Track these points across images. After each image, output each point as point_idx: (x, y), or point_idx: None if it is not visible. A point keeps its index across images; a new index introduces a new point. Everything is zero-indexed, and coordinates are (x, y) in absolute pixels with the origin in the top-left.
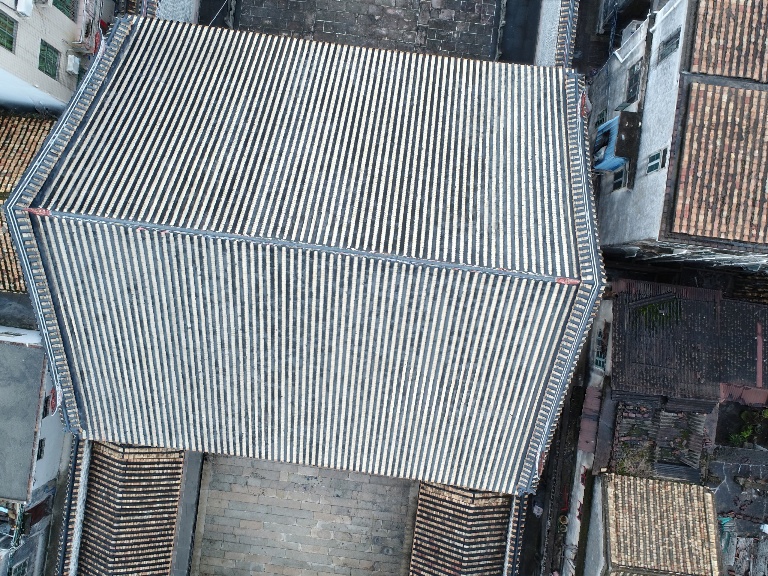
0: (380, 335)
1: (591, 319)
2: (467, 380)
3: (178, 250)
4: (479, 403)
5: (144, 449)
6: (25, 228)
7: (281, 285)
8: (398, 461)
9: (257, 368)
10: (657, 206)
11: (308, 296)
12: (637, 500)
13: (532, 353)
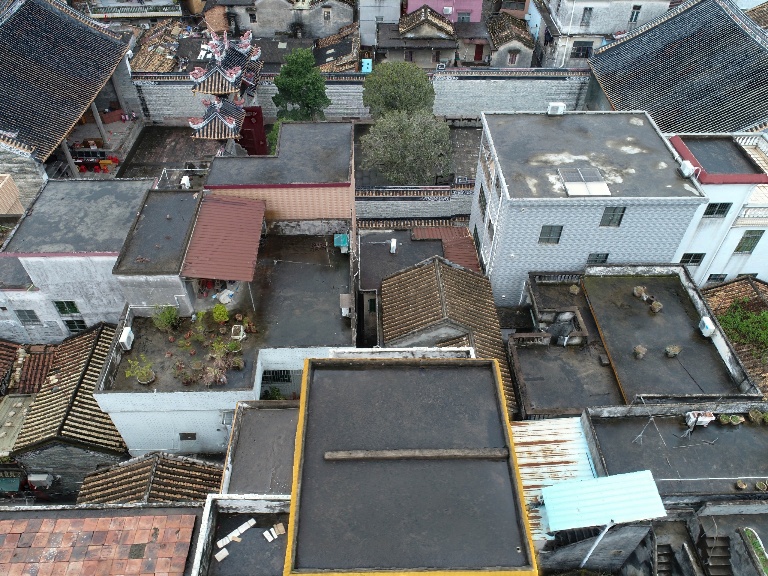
0: None
1: None
2: None
3: None
4: None
5: None
6: None
7: None
8: None
9: None
10: (656, 8)
11: None
12: None
13: None
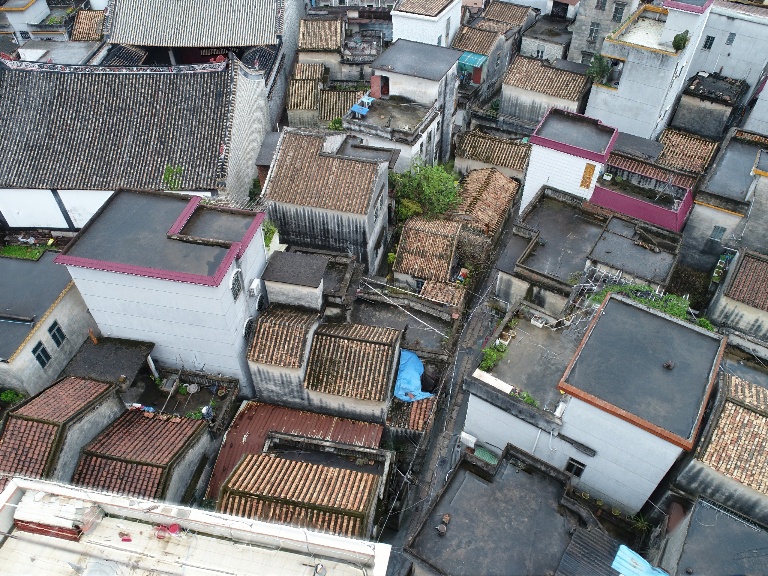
0: None
1: None
2: (254, 1)
3: None
4: (259, 8)
5: (131, 47)
6: None
7: None
8: None
9: (182, 6)
10: None
11: None
12: None
13: None
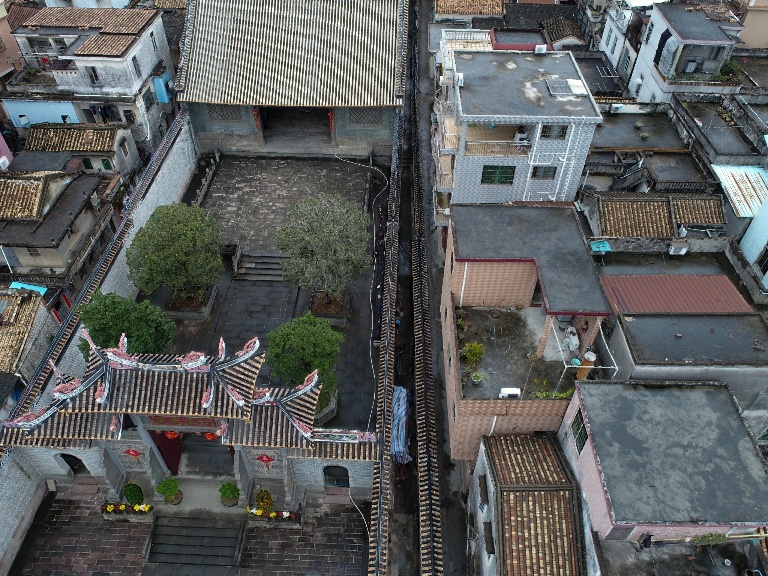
0: None
1: None
2: None
3: None
4: None
5: None
6: None
7: None
8: None
9: None
10: None
11: None
12: (184, 2)
13: None
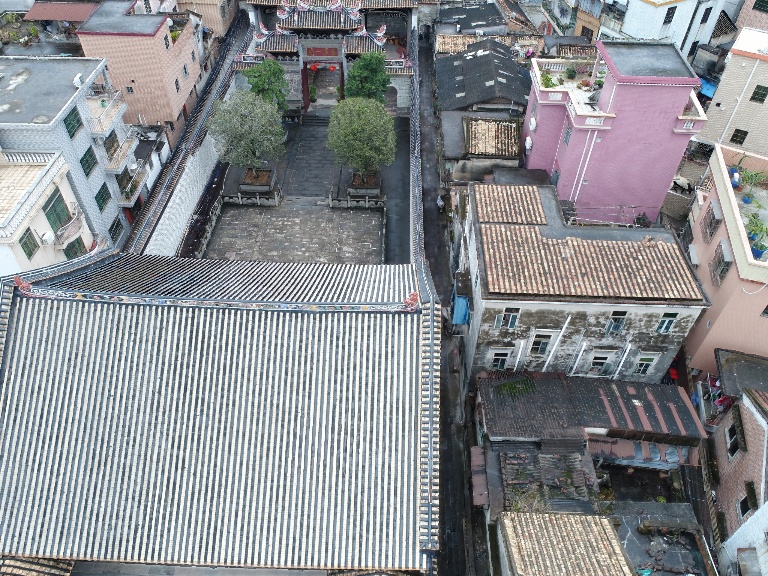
0: (277, 383)
1: (439, 336)
2: (355, 422)
3: (120, 319)
4: (369, 448)
5: (26, 564)
6: (6, 301)
7: (197, 343)
8: (298, 542)
9: (166, 434)
10: None
11: (218, 350)
12: (536, 529)
13: (404, 384)
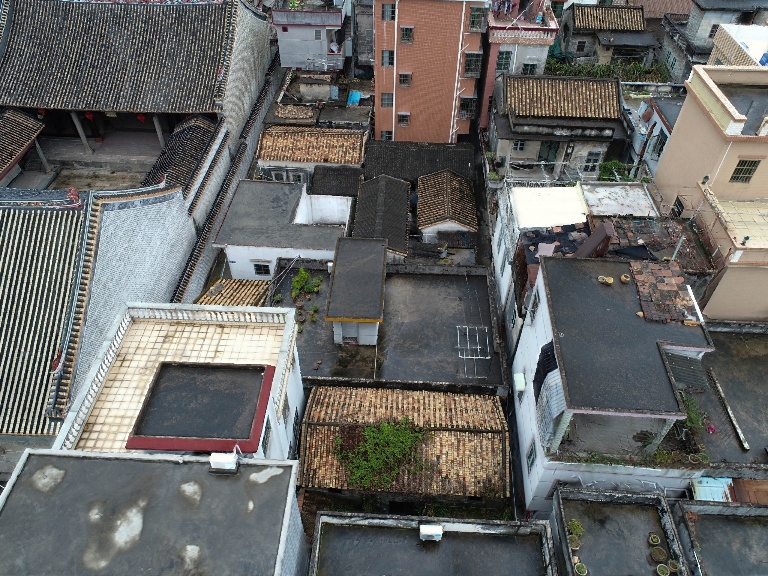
0: None
1: None
2: None
3: None
4: None
5: None
6: None
7: None
8: None
9: None
10: None
11: None
12: None
13: None
